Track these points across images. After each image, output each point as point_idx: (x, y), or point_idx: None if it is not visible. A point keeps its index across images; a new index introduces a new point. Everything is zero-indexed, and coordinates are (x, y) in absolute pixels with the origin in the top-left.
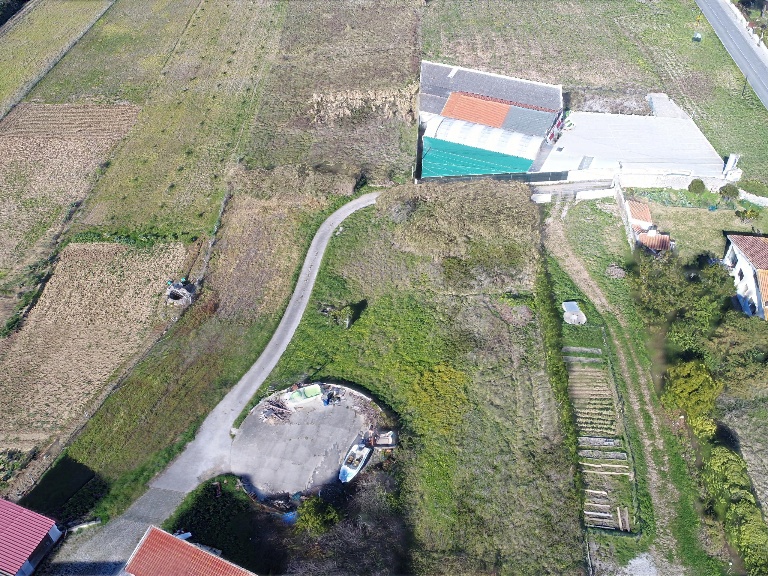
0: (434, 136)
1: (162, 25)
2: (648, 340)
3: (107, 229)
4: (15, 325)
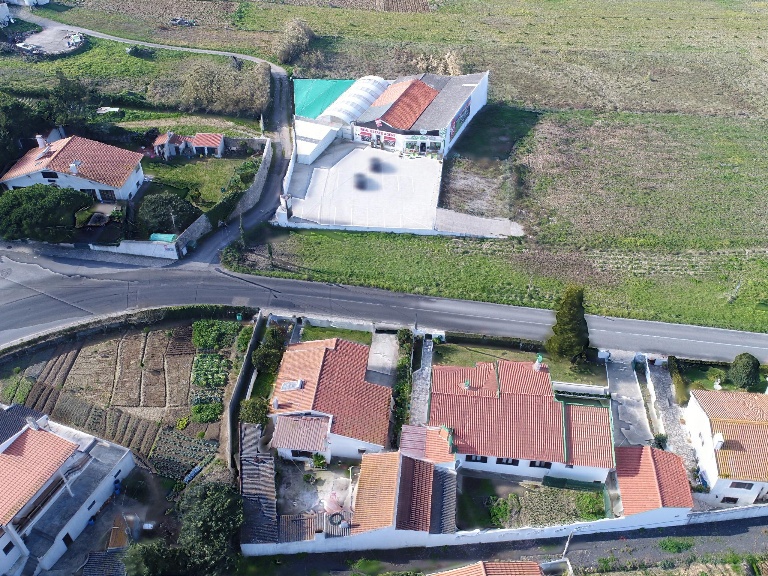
0: None
1: (597, 8)
2: None
3: (253, 8)
4: None
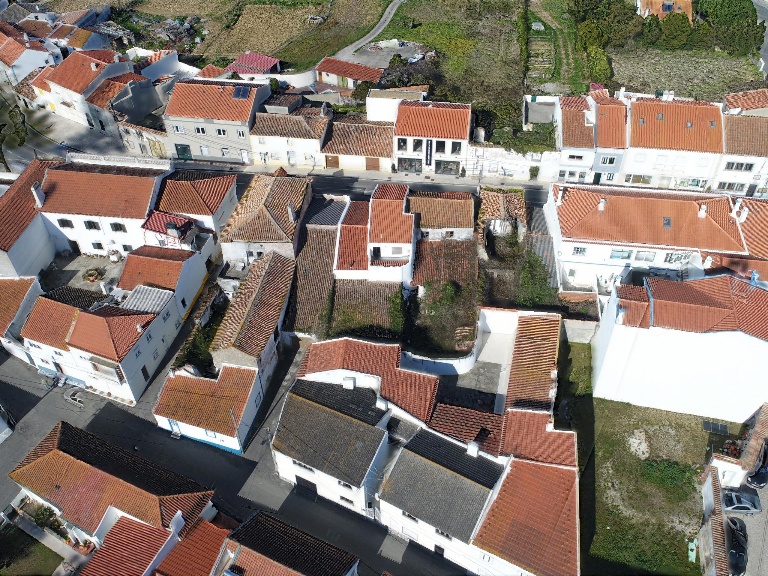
0: None
1: None
2: None
3: (267, 0)
4: (229, 27)
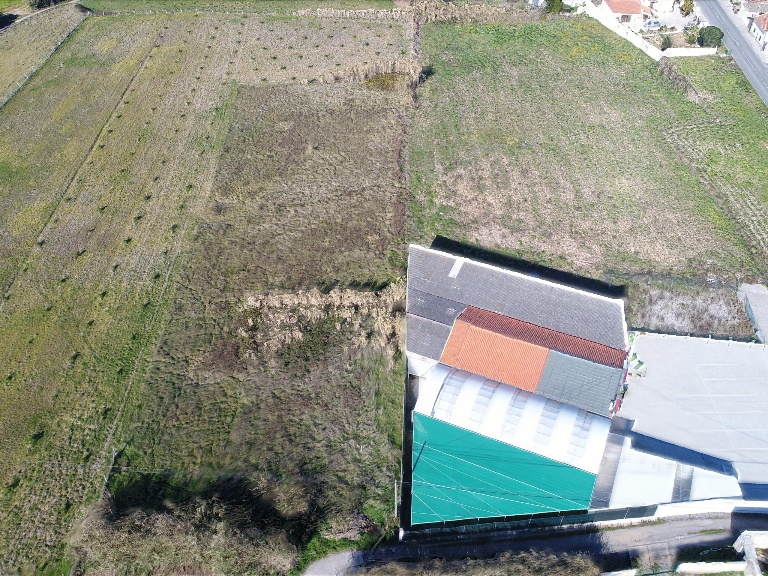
0: (430, 413)
1: (58, 146)
2: None
3: None
4: None
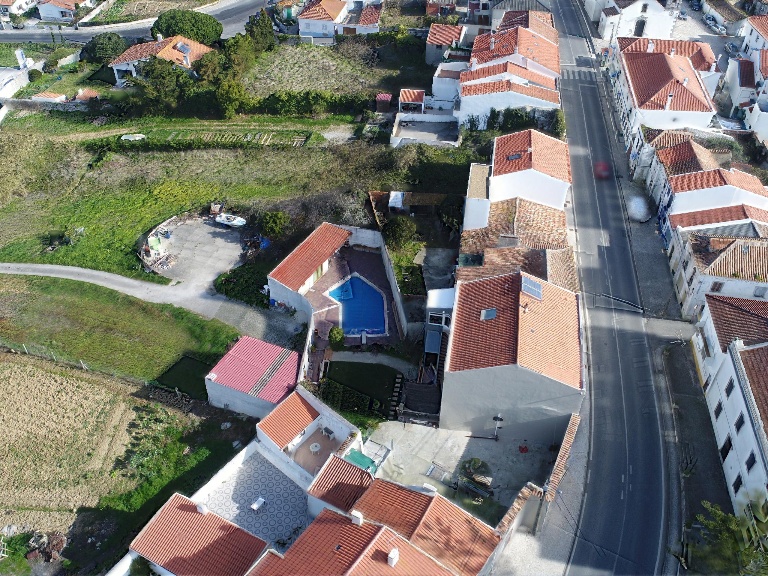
0: None
1: None
2: (175, 116)
3: None
4: None
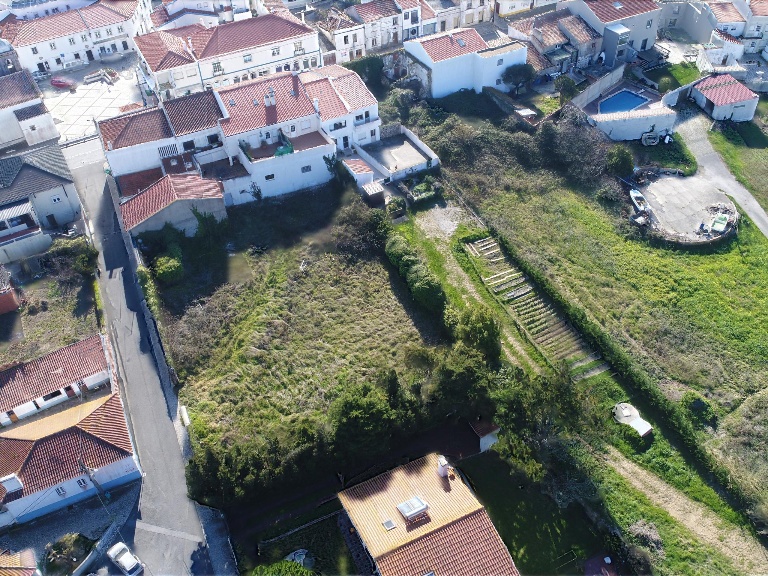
0: None
1: None
2: None
3: None
4: None
